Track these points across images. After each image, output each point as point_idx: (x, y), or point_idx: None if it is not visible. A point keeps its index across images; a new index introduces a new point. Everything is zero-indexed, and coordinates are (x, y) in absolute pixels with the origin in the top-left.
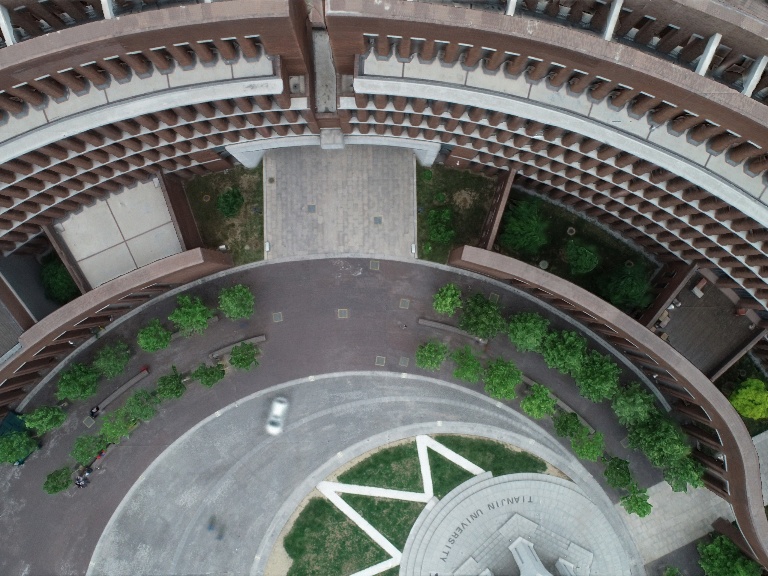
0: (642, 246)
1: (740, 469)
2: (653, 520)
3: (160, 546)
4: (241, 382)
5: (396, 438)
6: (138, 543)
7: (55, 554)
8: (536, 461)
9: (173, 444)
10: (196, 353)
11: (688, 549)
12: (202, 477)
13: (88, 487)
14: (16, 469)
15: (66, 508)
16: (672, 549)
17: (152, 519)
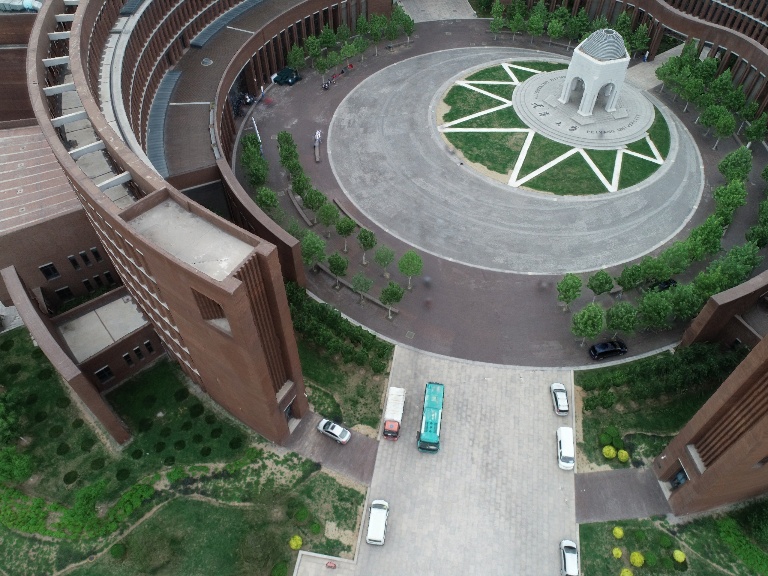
0: (579, 8)
1: (654, 3)
2: (641, 76)
3: (373, 107)
4: (404, 55)
5: (491, 64)
6: (360, 107)
7: (312, 114)
8: (567, 65)
9: (373, 74)
10: (379, 49)
11: (666, 83)
12: (391, 83)
13: (329, 90)
14: (288, 88)
15: (317, 98)
16: (658, 84)
17: (367, 98)
